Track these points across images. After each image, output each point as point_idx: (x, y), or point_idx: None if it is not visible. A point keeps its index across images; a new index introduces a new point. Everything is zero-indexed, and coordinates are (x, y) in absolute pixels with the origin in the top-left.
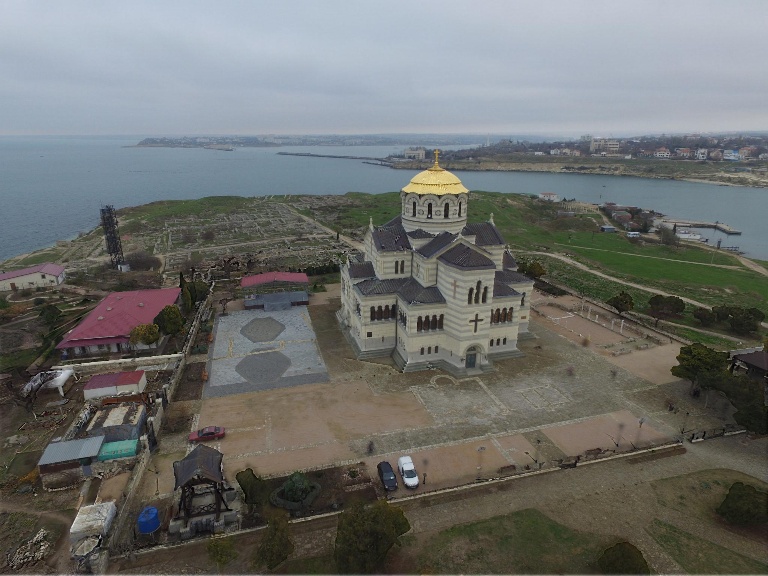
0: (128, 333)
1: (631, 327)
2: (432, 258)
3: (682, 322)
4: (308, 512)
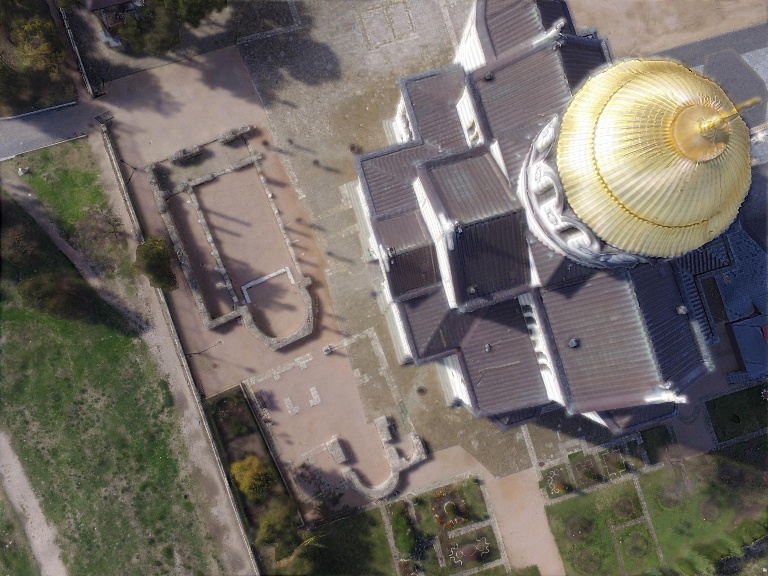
0: None
1: (171, 219)
2: None
3: (56, 262)
4: None
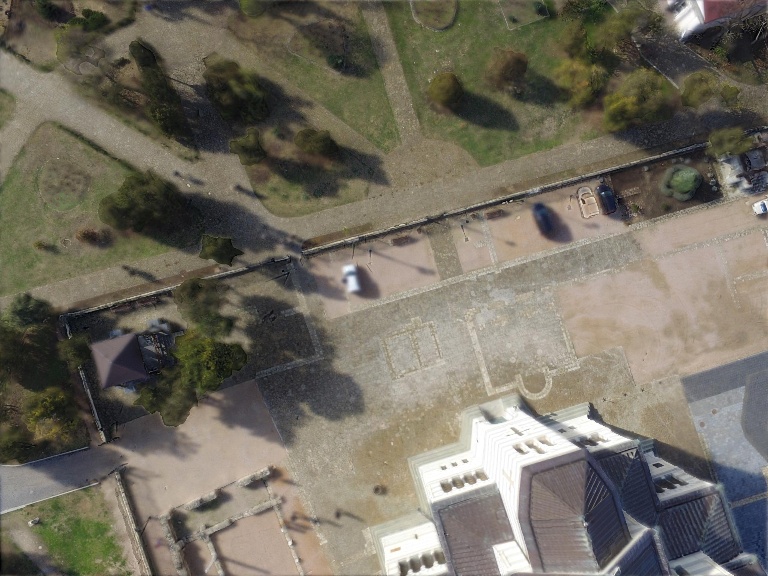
0: None
1: (187, 575)
2: None
3: None
4: (666, 163)
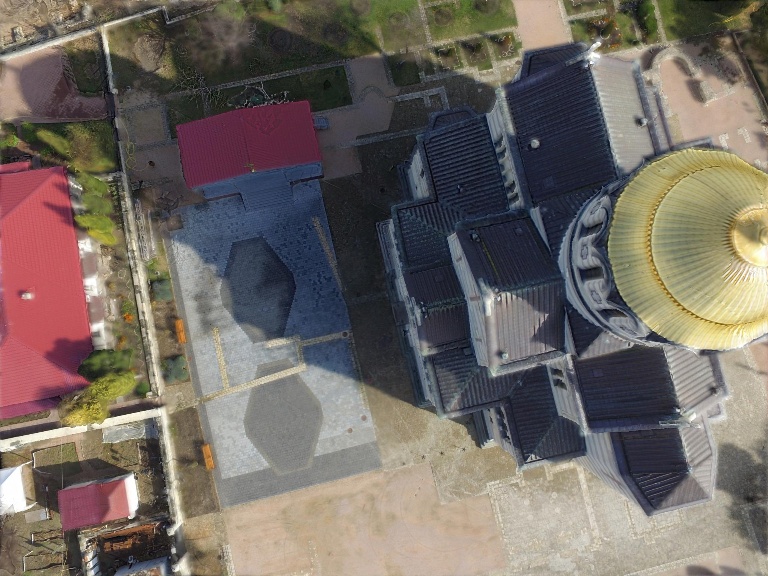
0: (51, 395)
1: None
2: (599, 429)
3: None
4: None
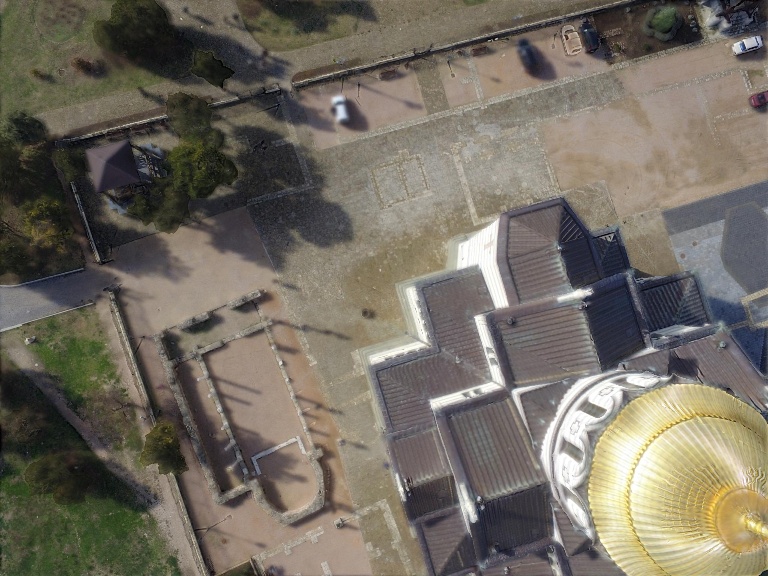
0: None
1: (180, 391)
2: None
3: (63, 435)
4: (648, 5)
